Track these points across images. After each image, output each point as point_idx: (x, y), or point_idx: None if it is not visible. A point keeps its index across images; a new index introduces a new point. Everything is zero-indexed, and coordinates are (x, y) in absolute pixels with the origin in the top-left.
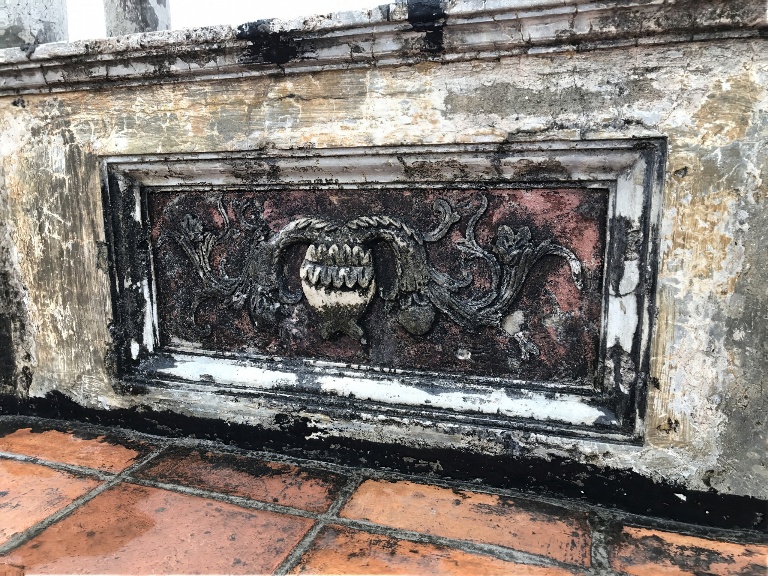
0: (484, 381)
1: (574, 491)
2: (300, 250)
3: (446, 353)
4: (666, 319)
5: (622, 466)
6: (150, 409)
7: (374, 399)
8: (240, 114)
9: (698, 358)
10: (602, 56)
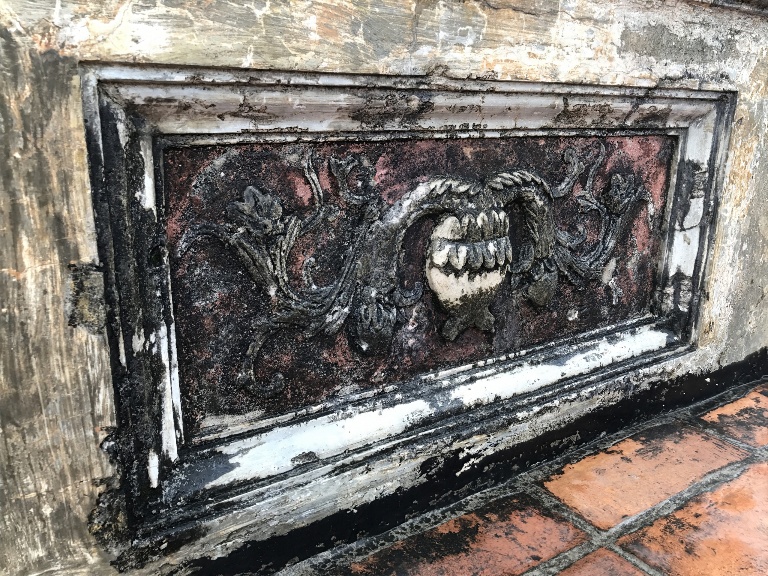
0: (588, 336)
1: (659, 407)
2: (423, 226)
3: (560, 318)
4: (719, 243)
5: (685, 372)
6: (207, 561)
7: (519, 393)
8: (403, 14)
9: (727, 270)
10: (719, 13)
